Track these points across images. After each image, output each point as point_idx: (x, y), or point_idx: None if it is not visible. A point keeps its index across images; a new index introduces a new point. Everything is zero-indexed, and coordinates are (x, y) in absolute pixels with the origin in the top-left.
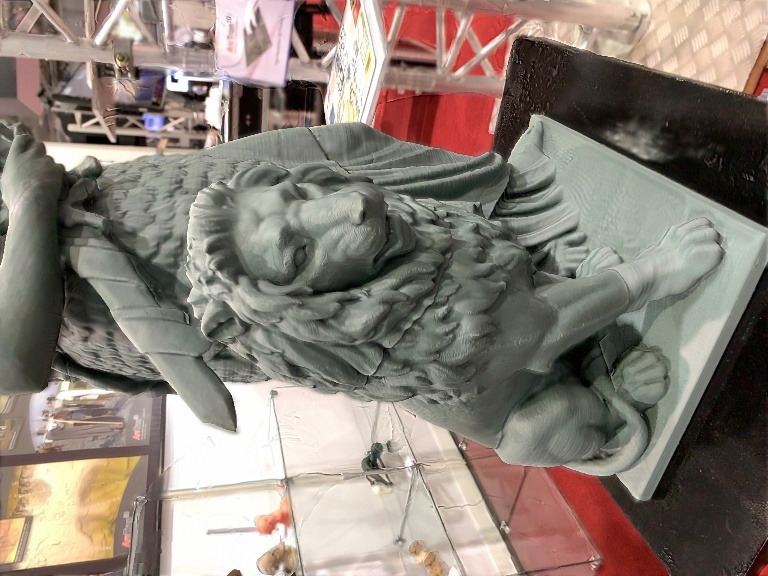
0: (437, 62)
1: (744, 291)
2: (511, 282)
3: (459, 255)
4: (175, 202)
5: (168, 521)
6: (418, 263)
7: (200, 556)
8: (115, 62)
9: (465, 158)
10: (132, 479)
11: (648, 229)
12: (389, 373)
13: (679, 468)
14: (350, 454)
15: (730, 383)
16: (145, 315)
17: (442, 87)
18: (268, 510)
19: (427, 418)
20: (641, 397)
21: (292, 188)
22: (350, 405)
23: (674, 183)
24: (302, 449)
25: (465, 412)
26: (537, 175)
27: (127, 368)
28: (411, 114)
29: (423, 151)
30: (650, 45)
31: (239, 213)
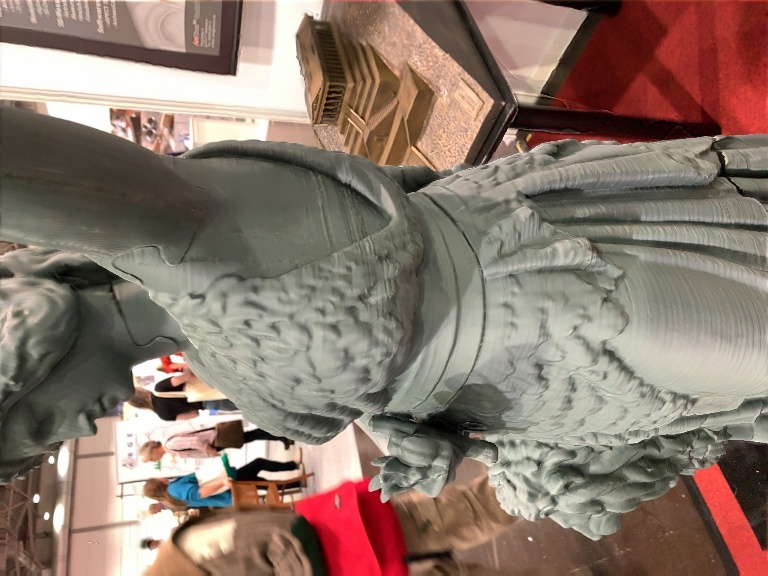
0: None
1: None
2: None
3: None
4: None
5: None
6: None
7: None
8: None
9: None
10: None
11: None
12: None
13: None
14: None
15: None
16: None
17: None
18: None
19: None
20: None
21: None
22: None
23: None
24: None
25: None
26: None
27: None
28: None
29: None
30: None
31: None
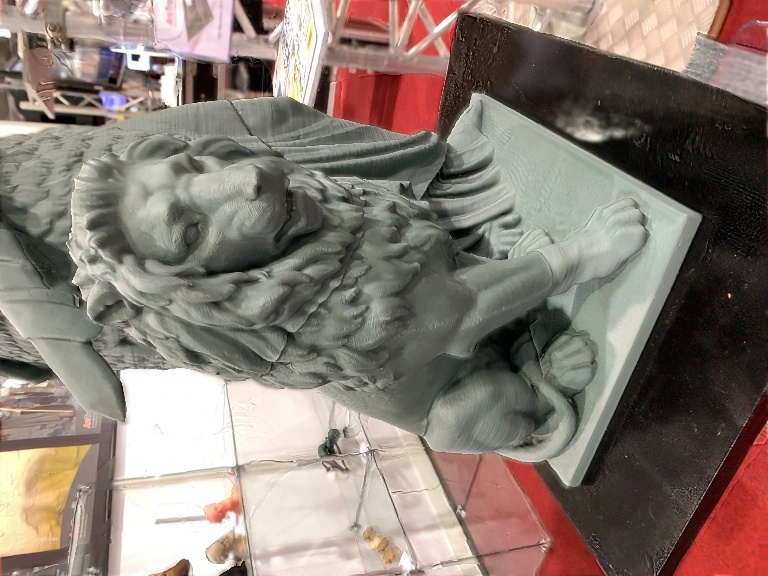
0: (390, 41)
1: (667, 274)
2: (427, 263)
3: (371, 235)
4: (71, 176)
5: (119, 511)
6: (323, 242)
7: (151, 545)
8: (46, 32)
9: (400, 136)
10: (81, 468)
11: (578, 211)
12: (294, 359)
13: (607, 454)
14: (308, 440)
15: (654, 368)
16: (28, 297)
17: (395, 67)
18: (223, 498)
19: (348, 405)
20: (568, 382)
21: (186, 160)
22: (309, 391)
23: (605, 163)
24: (255, 436)
25: (385, 399)
26: (475, 155)
27: (26, 355)
28: (373, 97)
29: (354, 128)
30: (602, 28)
31: (126, 187)
